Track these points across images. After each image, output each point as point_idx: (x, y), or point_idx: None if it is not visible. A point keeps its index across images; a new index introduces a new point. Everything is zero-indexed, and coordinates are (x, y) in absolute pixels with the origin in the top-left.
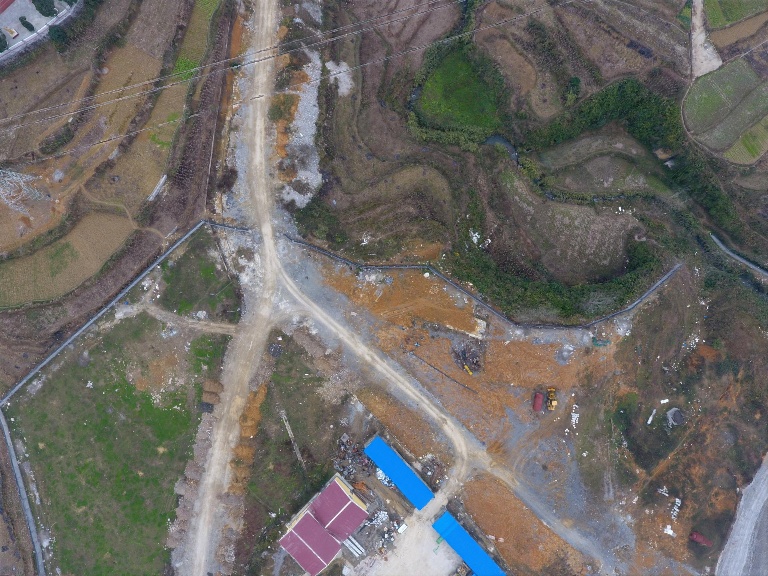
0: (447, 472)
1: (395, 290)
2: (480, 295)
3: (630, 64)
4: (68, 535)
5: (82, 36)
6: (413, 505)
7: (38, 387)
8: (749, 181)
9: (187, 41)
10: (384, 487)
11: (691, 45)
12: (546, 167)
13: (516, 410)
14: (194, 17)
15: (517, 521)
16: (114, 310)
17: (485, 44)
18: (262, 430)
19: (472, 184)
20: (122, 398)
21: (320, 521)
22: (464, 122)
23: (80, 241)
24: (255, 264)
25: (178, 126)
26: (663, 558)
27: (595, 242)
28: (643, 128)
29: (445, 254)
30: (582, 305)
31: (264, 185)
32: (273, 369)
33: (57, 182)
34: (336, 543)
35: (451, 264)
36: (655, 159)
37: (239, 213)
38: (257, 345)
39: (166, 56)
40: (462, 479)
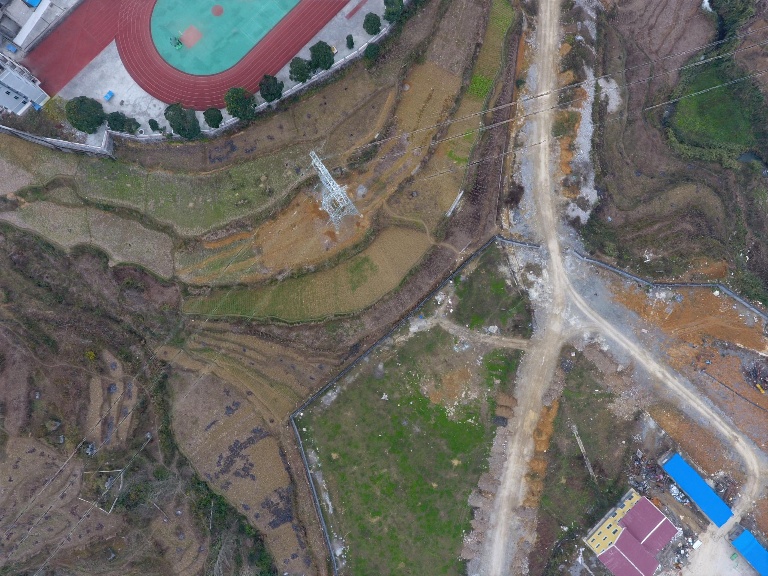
0: (739, 489)
1: (685, 308)
2: None
3: None
4: (362, 544)
5: (390, 53)
6: (706, 522)
7: (333, 398)
8: None
9: (481, 58)
10: (677, 503)
11: None
12: None
13: None
14: (488, 34)
15: None
16: (409, 324)
17: (745, 62)
18: (554, 444)
19: (734, 201)
20: (417, 411)
21: (634, 537)
22: (719, 139)
23: (379, 255)
24: (543, 280)
25: (474, 143)
26: None
27: None
28: None
29: (734, 273)
30: None
31: (549, 201)
32: (564, 384)
33: (361, 197)
34: (654, 559)
35: (740, 283)
36: None
37: (526, 229)
38: (549, 360)
39: (465, 73)
40: (754, 497)
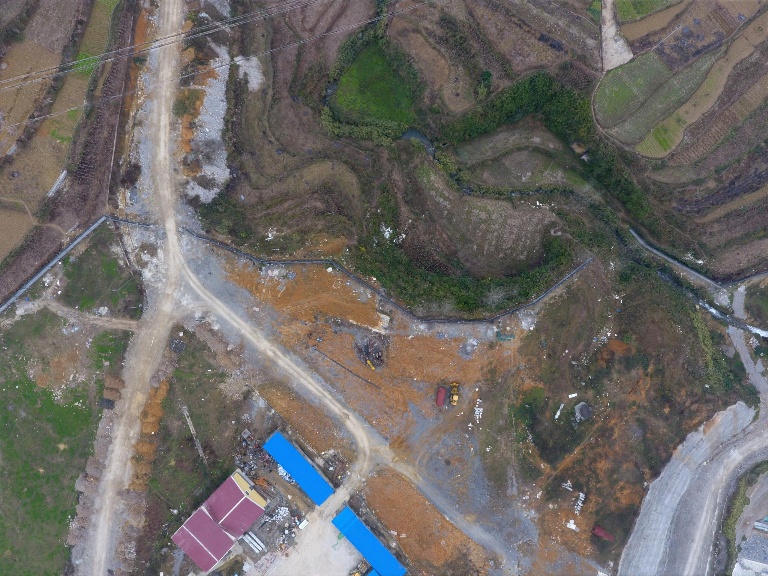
0: (349, 467)
1: (298, 285)
2: (383, 290)
3: (541, 58)
4: None
5: None
6: None
7: None
8: (662, 175)
9: (88, 36)
10: (286, 483)
11: (601, 38)
12: (463, 162)
13: (419, 405)
14: (95, 12)
15: (419, 516)
16: (15, 306)
17: (399, 38)
18: (164, 426)
19: (385, 179)
20: (23, 395)
21: (214, 517)
22: (379, 117)
23: None
24: (158, 260)
25: (78, 121)
26: (566, 553)
27: (512, 237)
28: (558, 122)
29: (349, 249)
30: None
31: (168, 180)
32: (175, 365)
33: None
34: (229, 539)
35: (355, 259)
36: (572, 153)
37: (143, 208)
38: (159, 341)
39: (65, 51)
40: (364, 474)
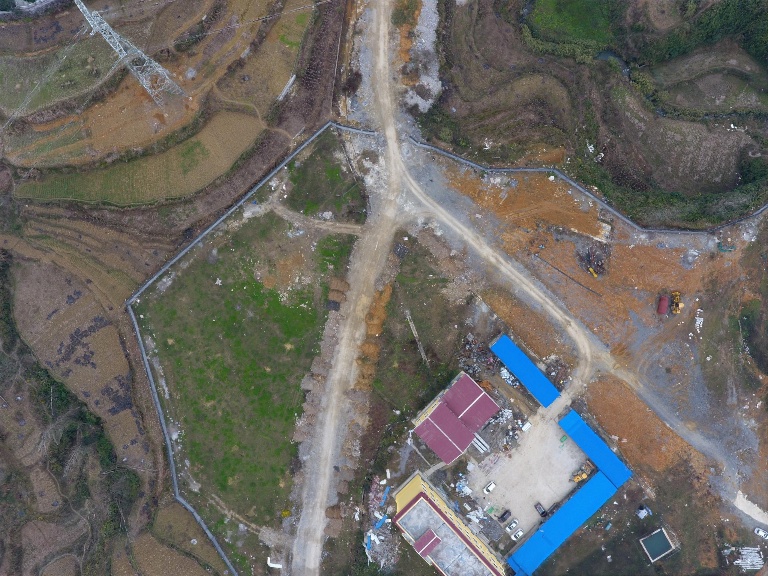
0: (571, 373)
1: (520, 193)
2: (605, 199)
3: None
4: (197, 428)
5: None
6: (537, 404)
7: (168, 284)
8: None
9: None
10: (508, 386)
11: None
12: (658, 83)
13: (640, 313)
14: None
15: (640, 422)
16: (242, 209)
17: None
18: (387, 329)
19: (587, 96)
20: (250, 295)
21: (453, 412)
22: (577, 36)
23: (211, 140)
24: (380, 167)
25: (307, 27)
26: None
27: (707, 159)
28: (761, 42)
29: (570, 158)
30: (709, 209)
31: (388, 89)
32: (398, 270)
33: (190, 80)
34: (470, 432)
35: (576, 168)
36: None
37: (363, 116)
38: (383, 245)
39: None
40: (586, 380)
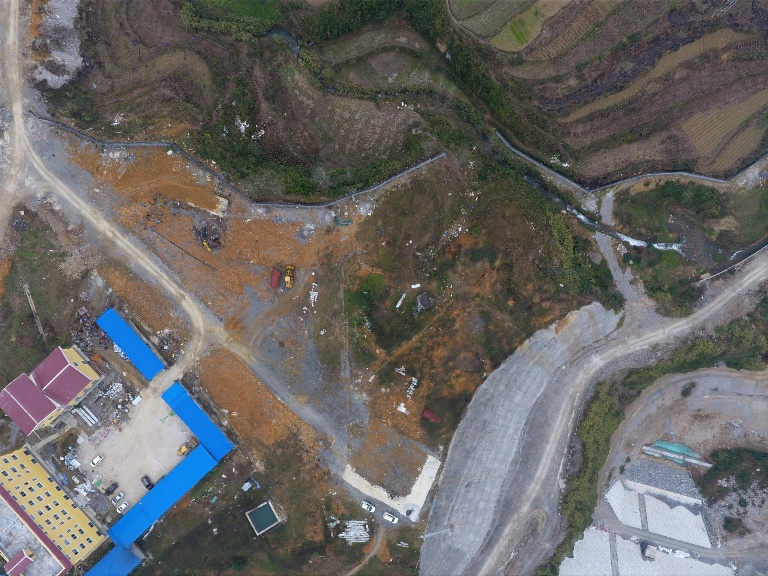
0: (183, 347)
1: (138, 167)
2: (223, 173)
3: None
4: None
5: None
6: None
7: None
8: (521, 70)
9: None
10: (121, 360)
11: None
12: (327, 61)
13: (255, 287)
14: None
15: (251, 396)
16: None
17: None
18: (5, 303)
19: (243, 73)
20: None
21: (39, 384)
22: (244, 14)
23: None
24: (4, 142)
25: None
26: (396, 435)
27: (375, 136)
28: (420, 19)
29: (190, 132)
30: None
31: (17, 65)
32: (18, 244)
33: None
34: (51, 404)
35: (195, 142)
36: (438, 53)
37: None
38: (1, 220)
39: None
40: (198, 354)
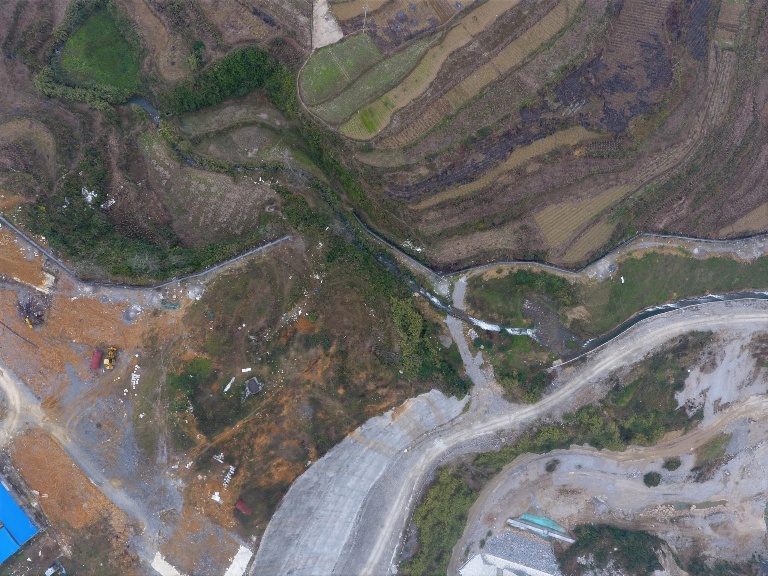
0: None
1: None
2: (51, 249)
3: (254, 31)
4: None
5: None
6: None
7: None
8: (371, 157)
9: None
10: None
11: (313, 16)
12: (186, 132)
13: (76, 367)
14: None
15: (64, 478)
16: None
17: (124, 3)
18: None
19: (94, 142)
20: None
21: None
22: (104, 81)
23: None
24: None
25: None
26: (209, 524)
27: (229, 211)
28: (278, 98)
29: (21, 206)
30: None
31: None
32: None
33: None
34: None
35: (26, 216)
36: (298, 132)
37: None
38: None
39: None
40: (12, 432)
